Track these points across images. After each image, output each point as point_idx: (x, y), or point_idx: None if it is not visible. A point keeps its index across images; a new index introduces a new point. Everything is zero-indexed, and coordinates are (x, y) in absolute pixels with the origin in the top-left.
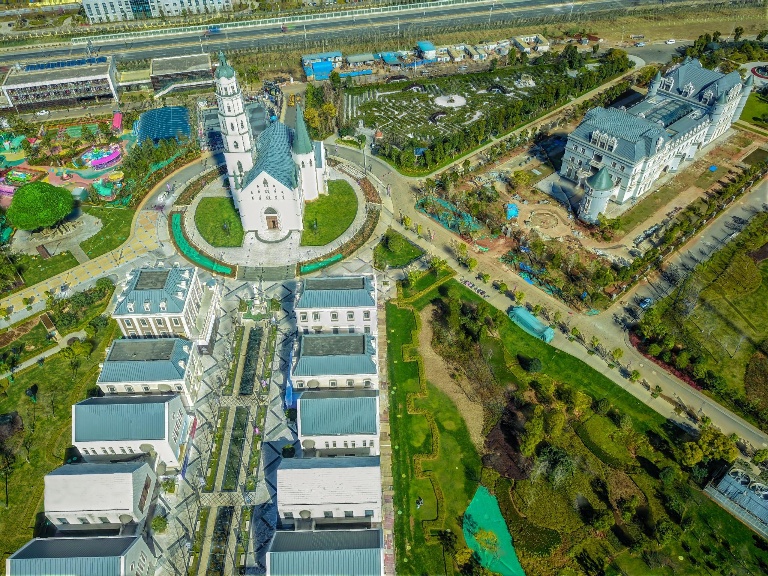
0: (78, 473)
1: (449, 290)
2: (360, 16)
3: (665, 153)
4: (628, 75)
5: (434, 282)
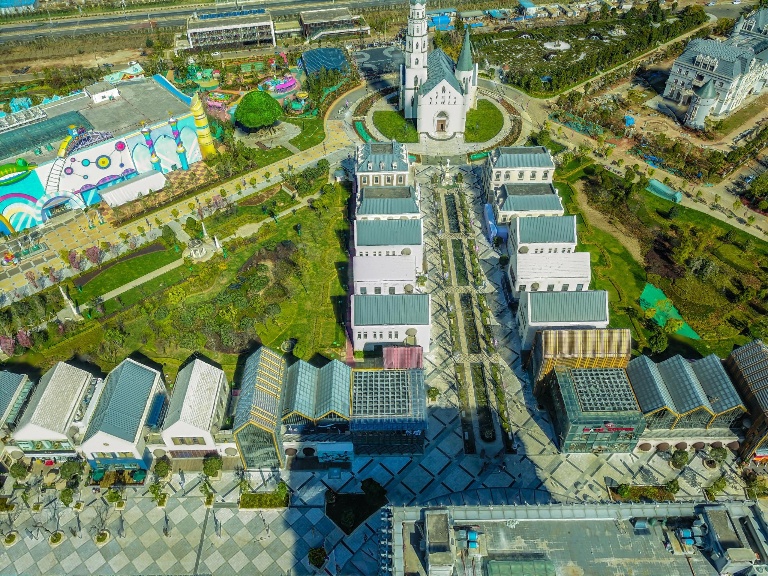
0: None
1: (596, 167)
2: None
3: (754, 75)
4: (704, 27)
5: (579, 166)
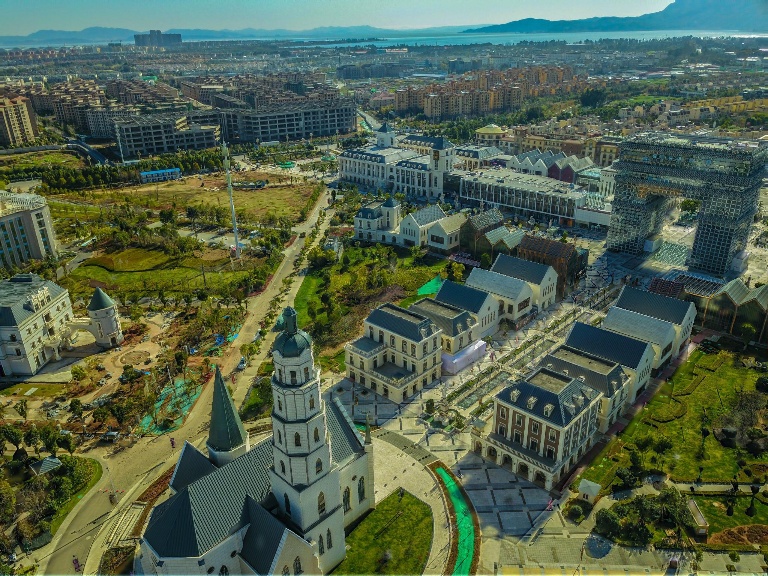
0: (649, 319)
1: None
2: None
3: None
4: None
5: None
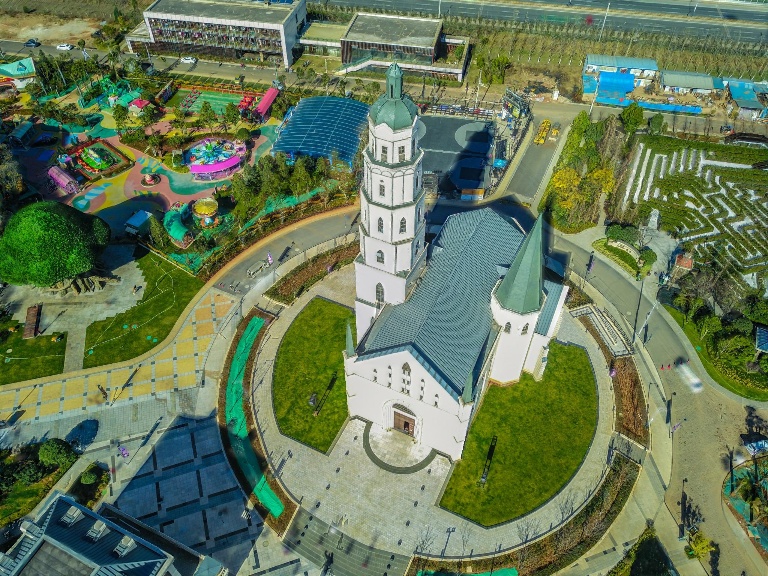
0: None
1: None
2: (705, 2)
3: None
4: None
5: None
